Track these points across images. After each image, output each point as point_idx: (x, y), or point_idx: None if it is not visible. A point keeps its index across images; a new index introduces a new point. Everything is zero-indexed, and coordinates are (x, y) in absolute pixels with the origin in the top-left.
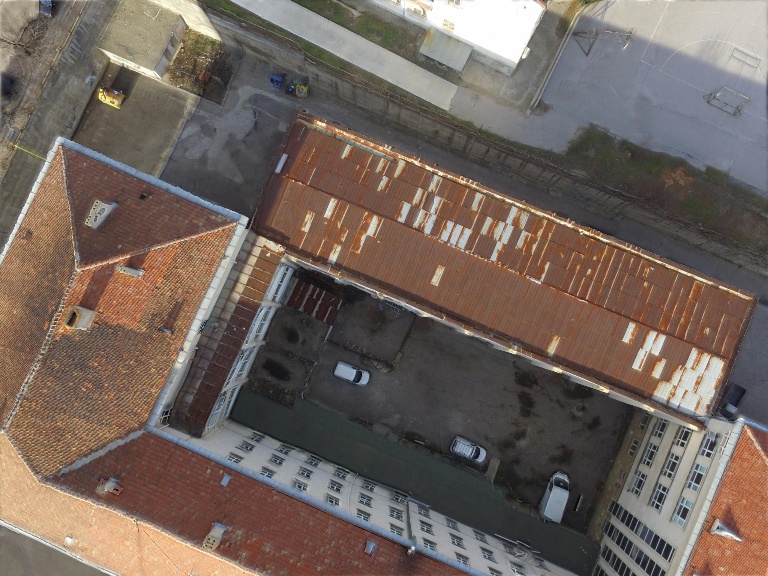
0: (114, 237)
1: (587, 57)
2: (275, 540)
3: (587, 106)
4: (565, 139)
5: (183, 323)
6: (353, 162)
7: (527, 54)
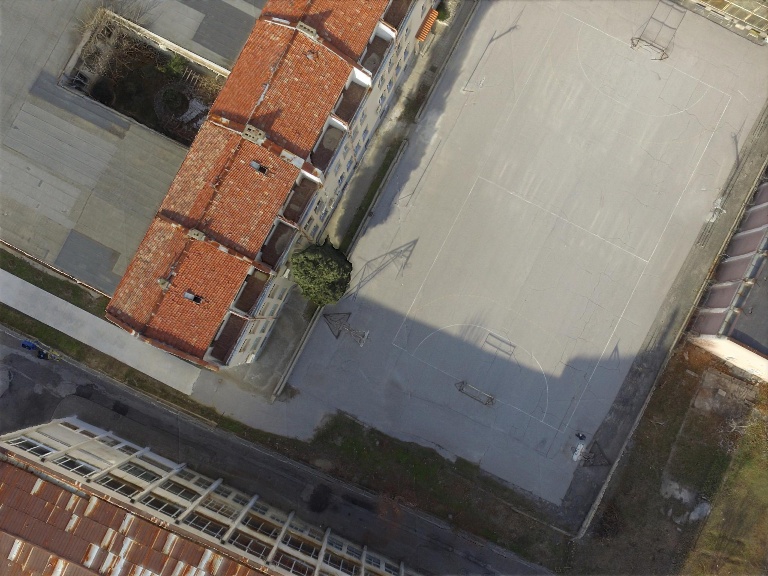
0: None
1: (337, 340)
2: None
3: (335, 391)
4: (311, 426)
5: None
6: (42, 498)
7: (251, 361)
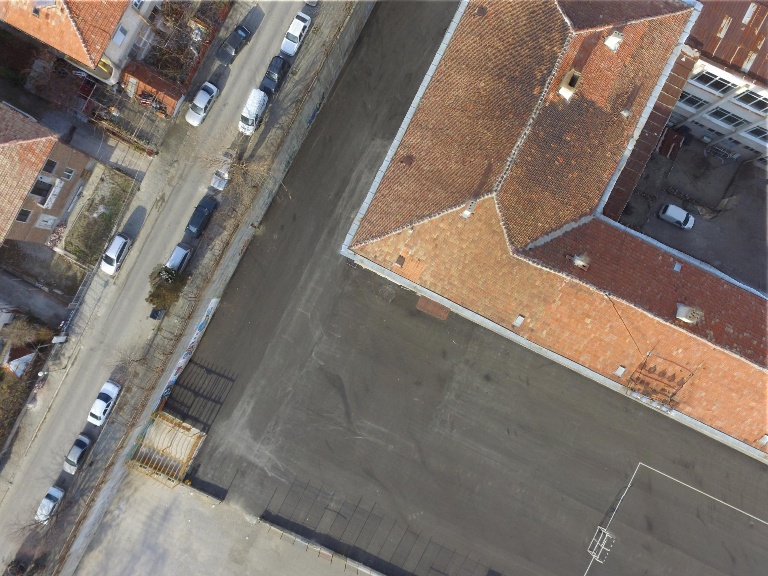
0: (592, 7)
1: None
2: (736, 323)
3: None
4: None
5: (636, 109)
6: None
7: None
